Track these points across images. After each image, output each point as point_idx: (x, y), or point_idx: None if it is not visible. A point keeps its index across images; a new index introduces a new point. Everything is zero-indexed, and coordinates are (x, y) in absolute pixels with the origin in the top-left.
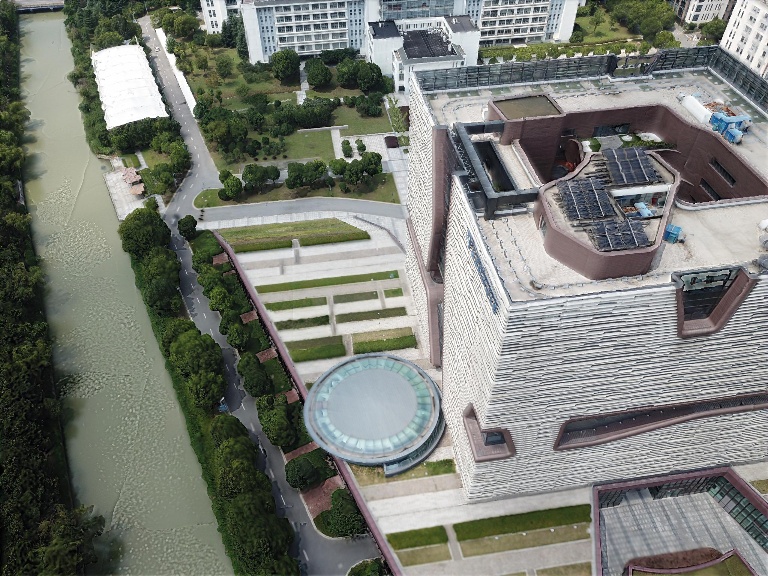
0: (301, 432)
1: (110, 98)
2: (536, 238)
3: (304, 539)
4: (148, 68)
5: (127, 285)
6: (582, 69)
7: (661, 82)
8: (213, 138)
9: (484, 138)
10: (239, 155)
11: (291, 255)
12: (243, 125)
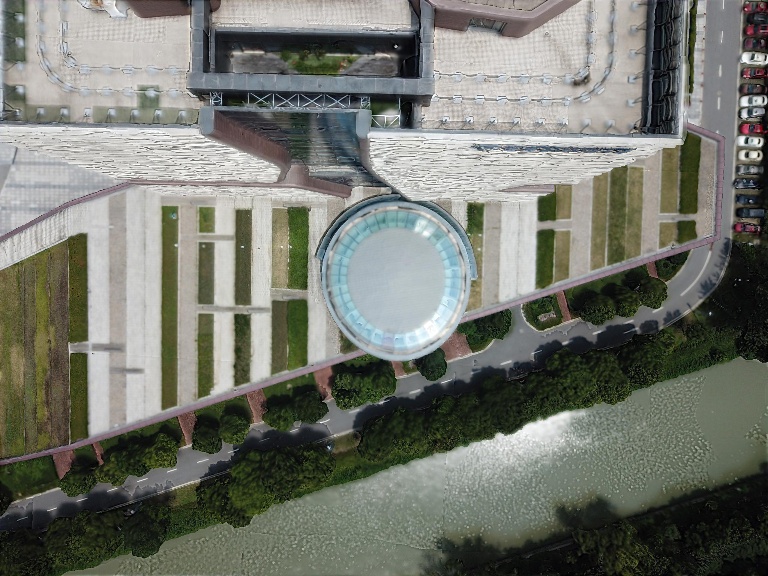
0: (373, 358)
1: None
2: (484, 41)
3: (490, 363)
4: None
5: (70, 575)
6: None
7: None
8: None
9: None
10: None
11: (104, 356)
12: None
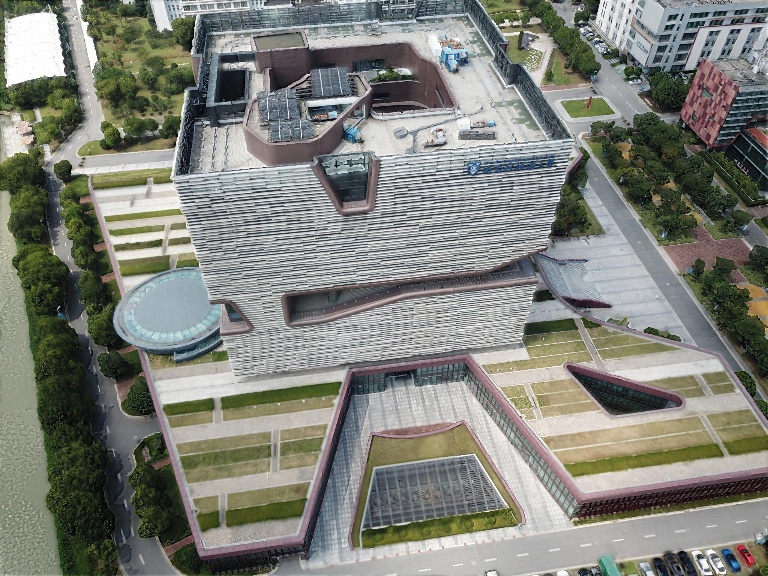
0: None
1: (14, 59)
2: None
3: (109, 418)
4: (56, 33)
5: None
6: (353, 14)
7: (422, 26)
8: (103, 95)
9: (241, 67)
10: (127, 111)
11: (144, 191)
12: (132, 83)
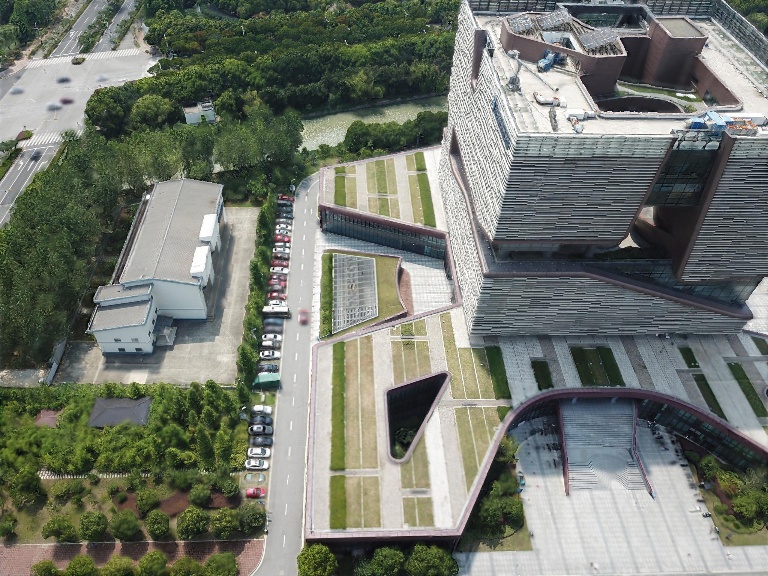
0: None
1: None
2: None
3: None
4: None
5: None
6: None
7: None
8: None
9: None
10: None
11: None
12: None
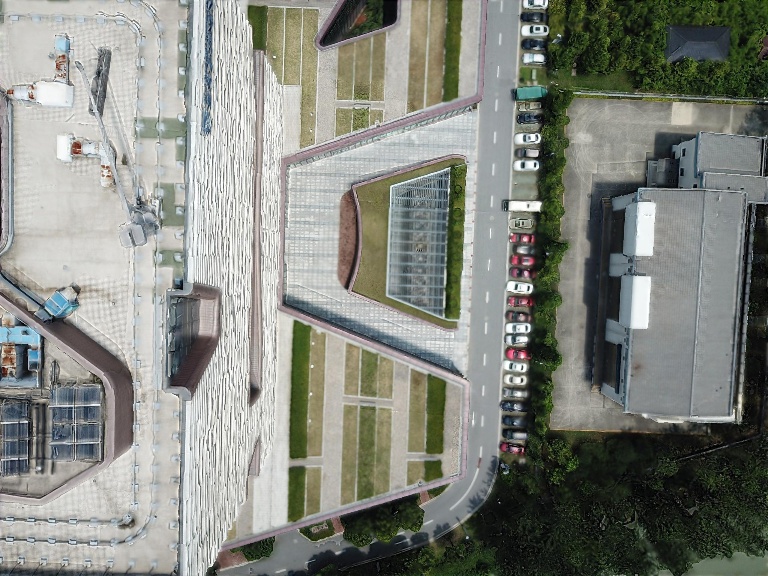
0: None
1: None
2: None
3: (266, 571)
4: None
5: None
6: None
7: None
8: None
9: None
10: None
11: None
12: None
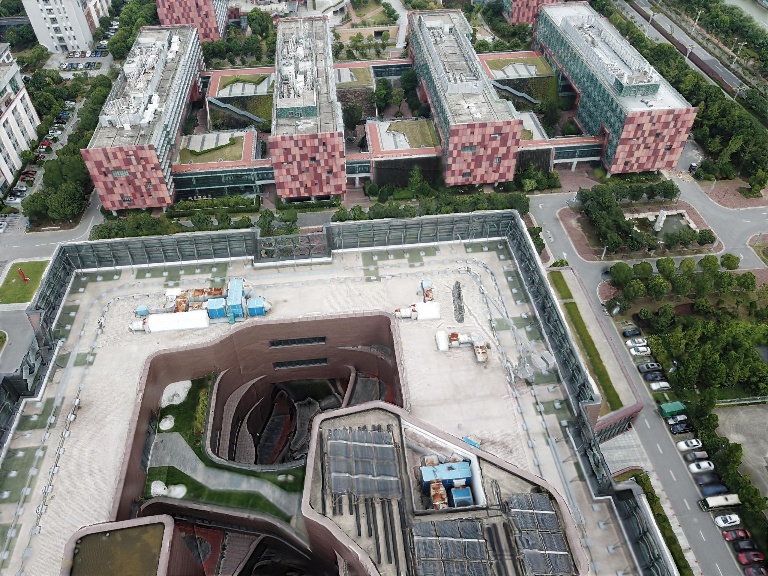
0: None
1: None
2: None
3: None
4: None
5: None
6: None
7: (80, 335)
8: None
9: None
10: None
11: None
12: None
